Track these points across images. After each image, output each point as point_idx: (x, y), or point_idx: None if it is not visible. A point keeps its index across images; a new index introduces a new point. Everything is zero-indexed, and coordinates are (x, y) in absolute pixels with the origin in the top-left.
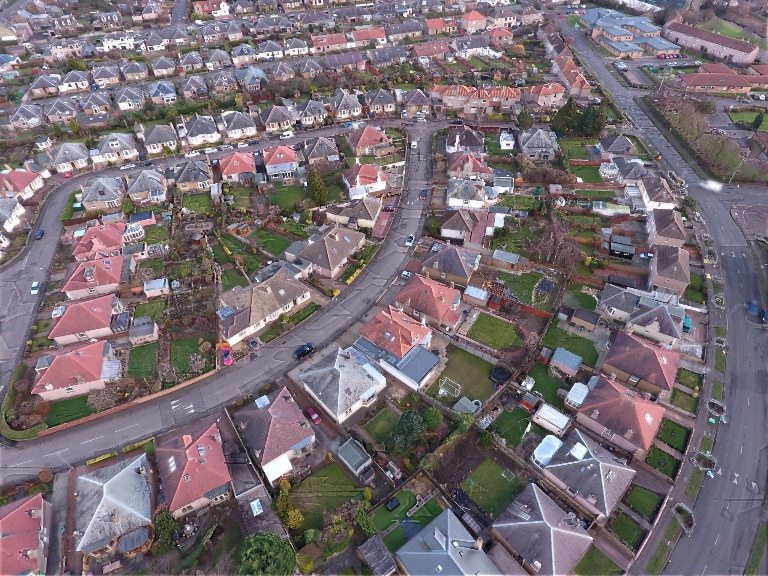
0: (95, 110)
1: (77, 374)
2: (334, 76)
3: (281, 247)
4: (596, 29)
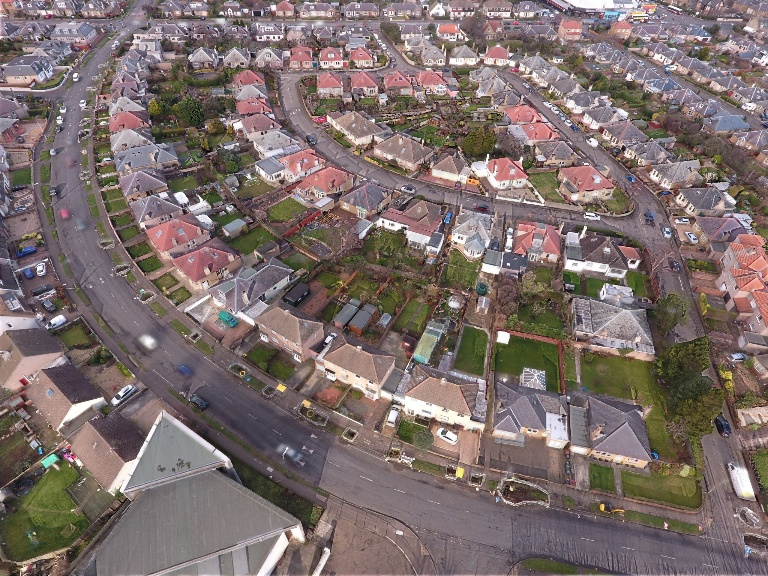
0: (615, 68)
1: None
2: None
3: None
4: None
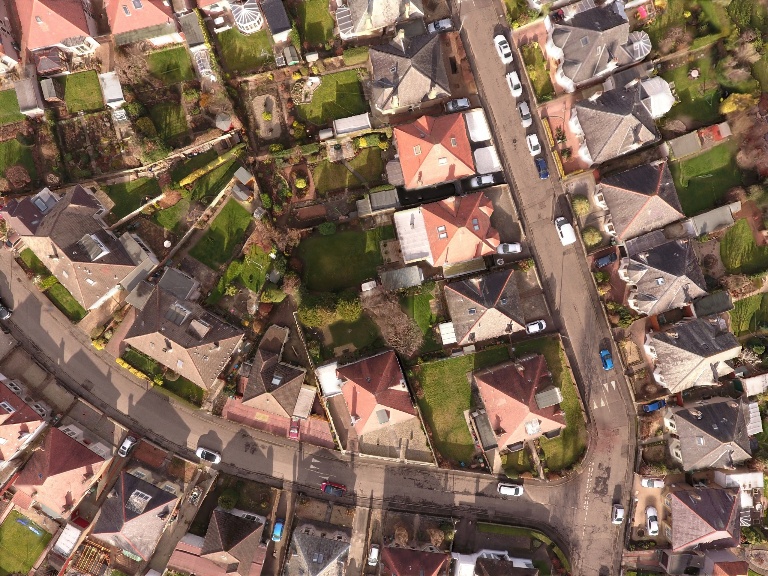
0: None
1: None
2: None
3: (207, 257)
4: None
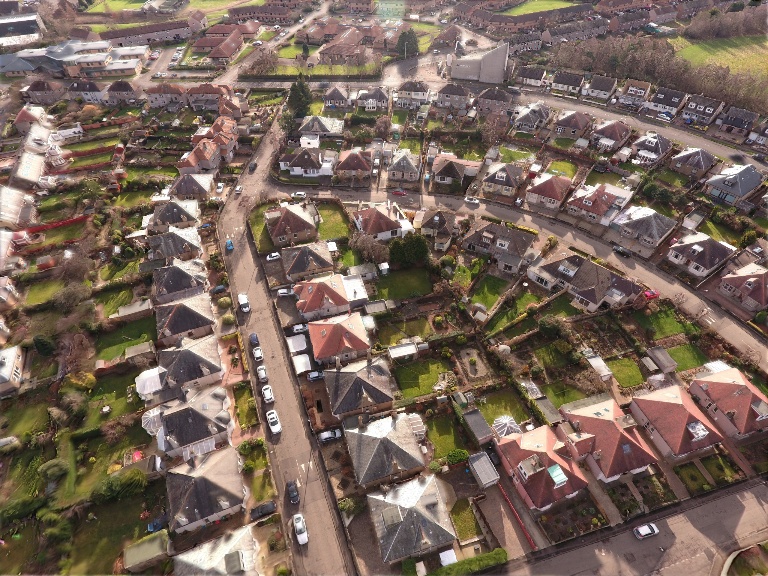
0: None
1: (748, 381)
2: (44, 265)
3: (497, 281)
4: (72, 66)
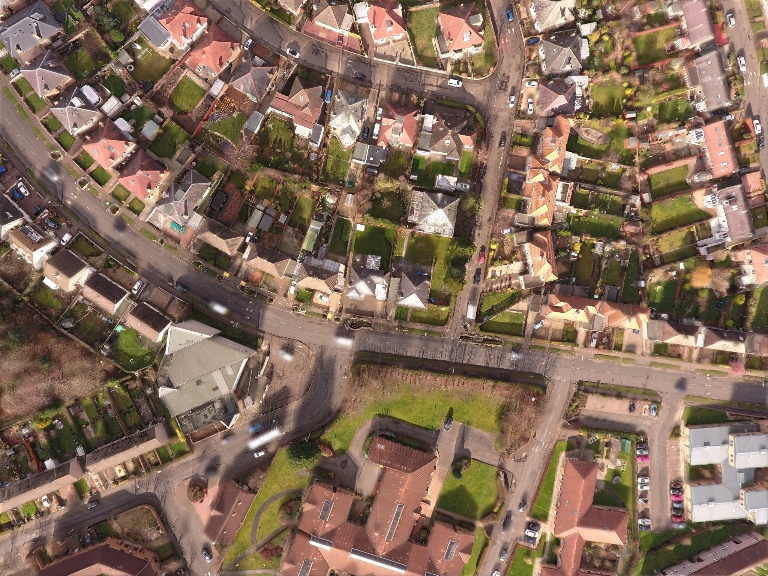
0: None
1: None
2: (651, 2)
3: None
4: None
